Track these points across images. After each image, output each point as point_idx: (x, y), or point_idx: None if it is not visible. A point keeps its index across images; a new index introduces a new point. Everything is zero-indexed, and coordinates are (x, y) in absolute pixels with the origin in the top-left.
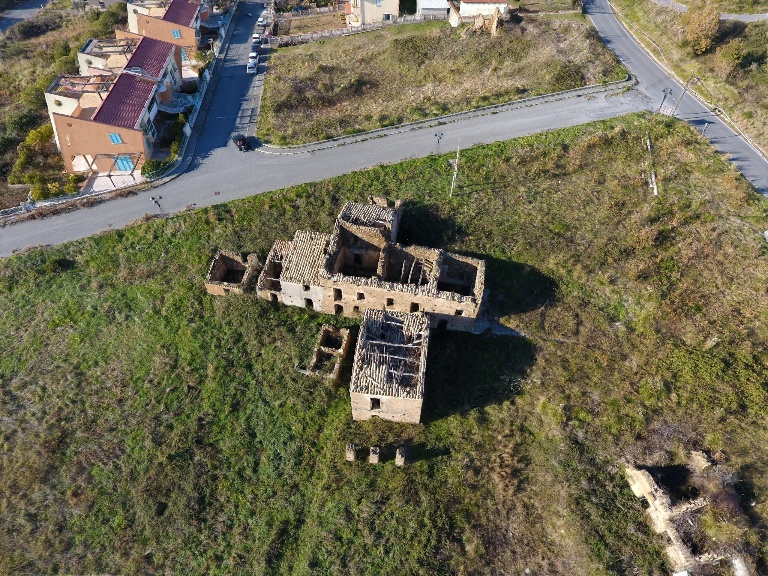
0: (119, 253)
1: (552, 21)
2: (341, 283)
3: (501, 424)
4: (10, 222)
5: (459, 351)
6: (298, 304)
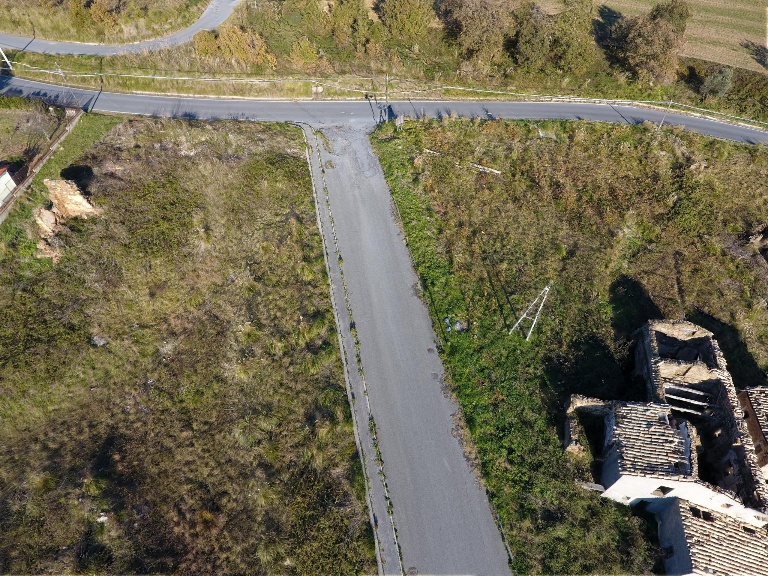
0: None
1: (110, 142)
2: None
3: None
4: None
5: None
6: None
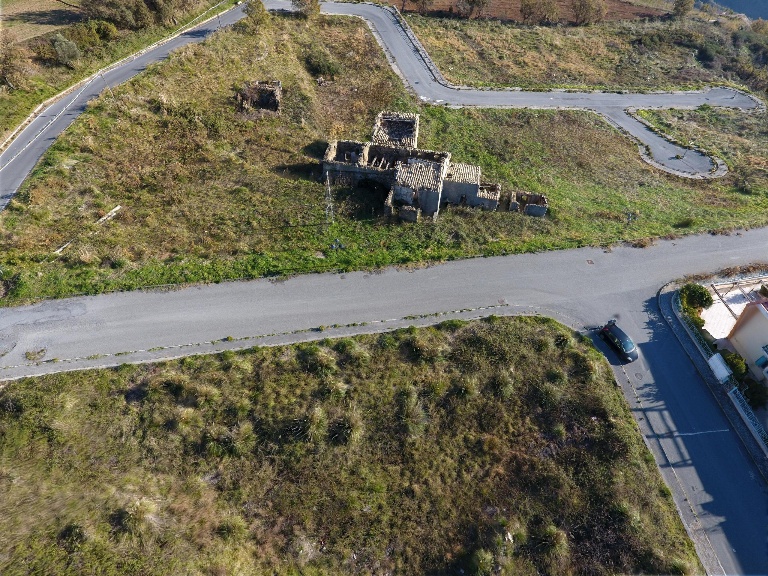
0: None
1: None
2: None
3: None
4: None
5: None
6: None
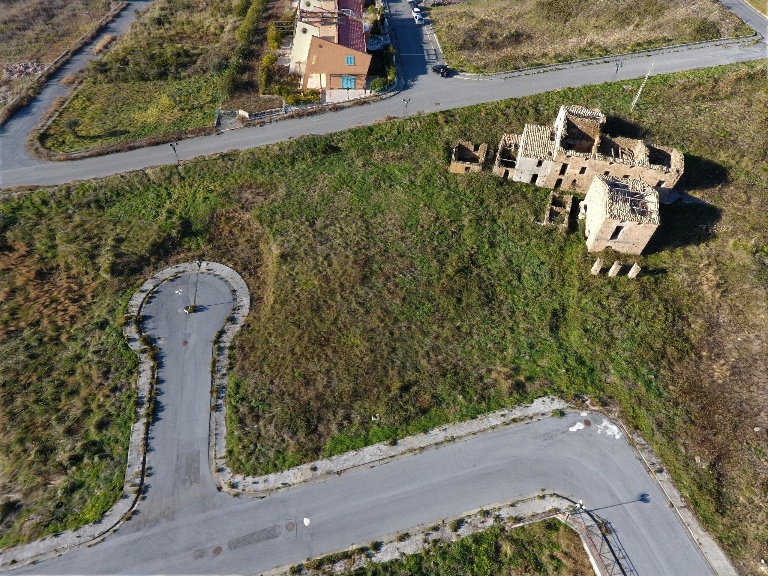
0: (372, 143)
1: None
2: (572, 158)
3: (700, 258)
4: (275, 120)
5: None
6: (524, 180)
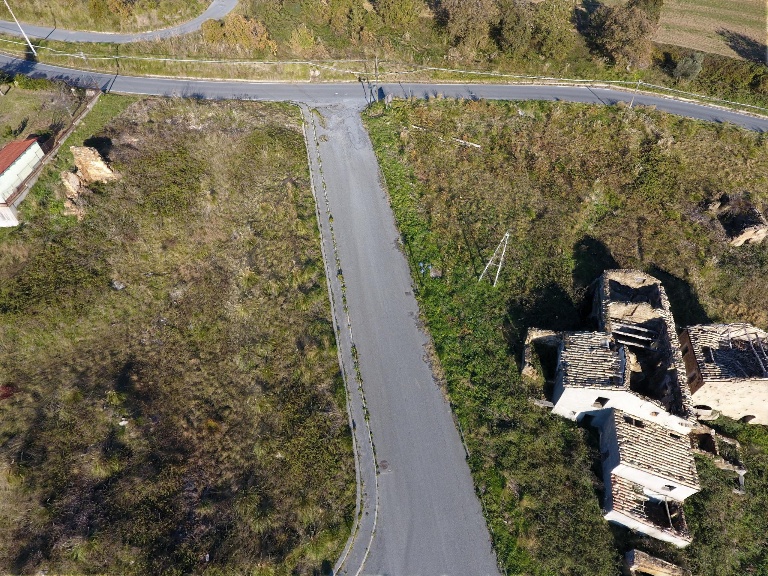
0: None
1: (126, 117)
2: None
3: None
4: None
5: None
6: None
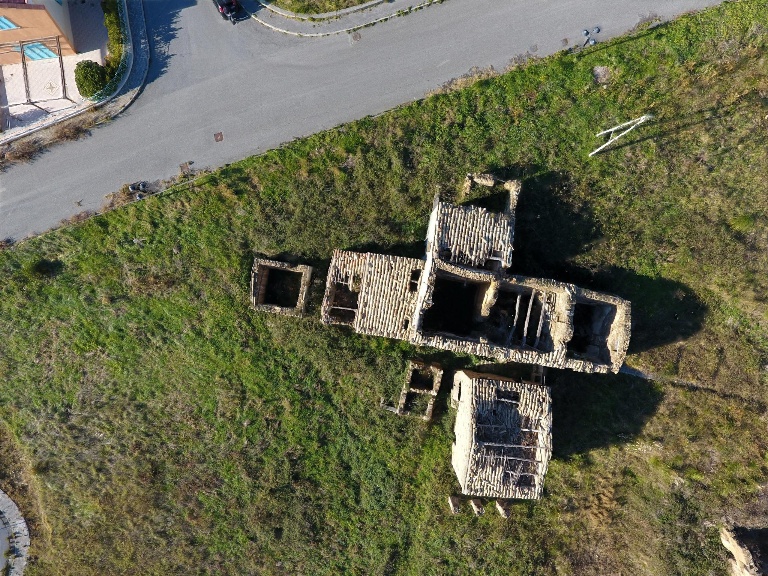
0: (113, 249)
1: None
2: None
3: (605, 468)
4: None
5: (568, 383)
6: None
